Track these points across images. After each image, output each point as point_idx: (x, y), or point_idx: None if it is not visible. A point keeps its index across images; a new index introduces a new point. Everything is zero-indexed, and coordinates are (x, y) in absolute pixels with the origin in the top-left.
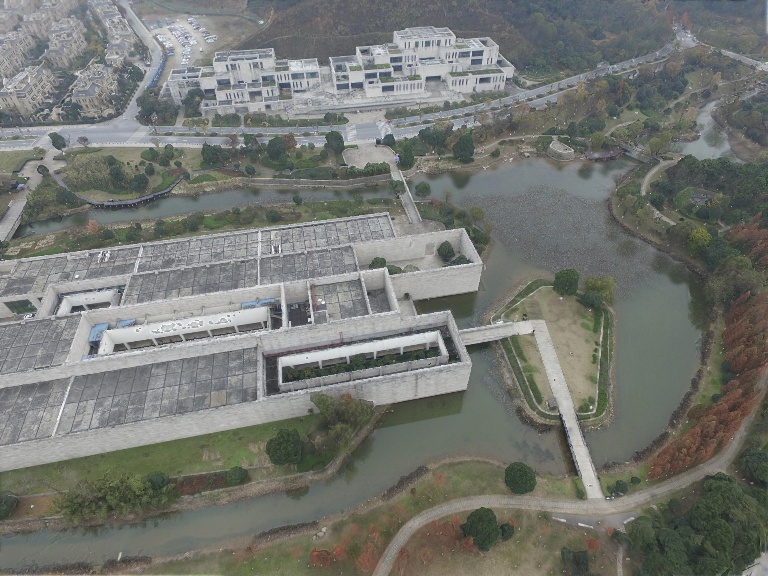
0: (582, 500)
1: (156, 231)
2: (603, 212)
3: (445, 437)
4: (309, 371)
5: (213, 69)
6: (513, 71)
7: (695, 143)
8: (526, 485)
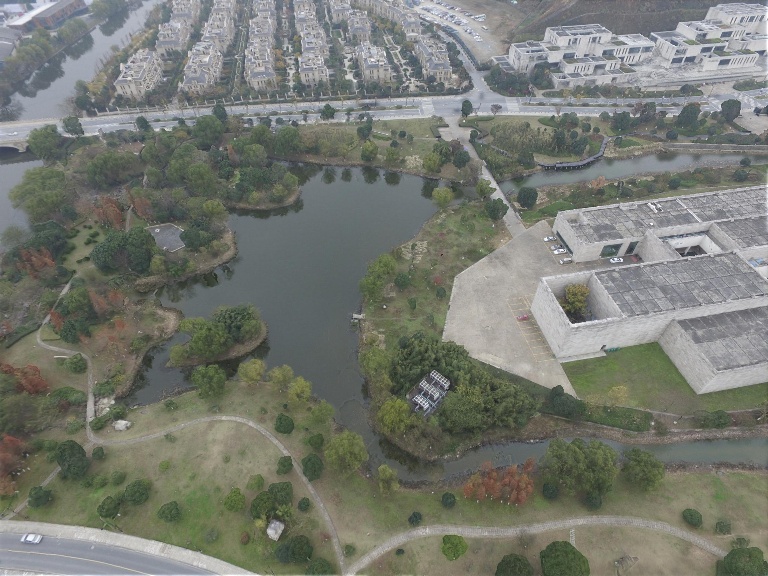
0: None
1: (653, 188)
2: None
3: None
4: None
5: (551, 44)
6: None
7: None
8: None
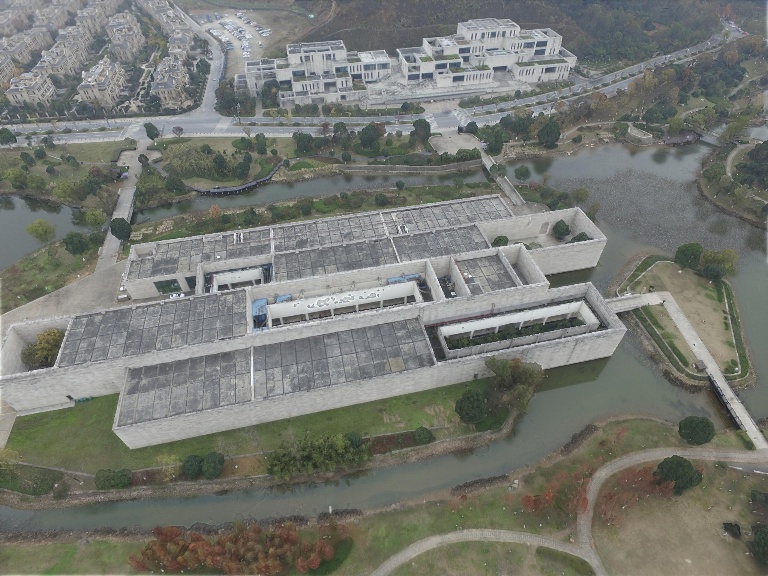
0: (751, 450)
1: (275, 215)
2: (694, 193)
3: (603, 399)
4: (467, 340)
5: (286, 61)
6: (575, 61)
7: (761, 128)
8: (709, 435)
